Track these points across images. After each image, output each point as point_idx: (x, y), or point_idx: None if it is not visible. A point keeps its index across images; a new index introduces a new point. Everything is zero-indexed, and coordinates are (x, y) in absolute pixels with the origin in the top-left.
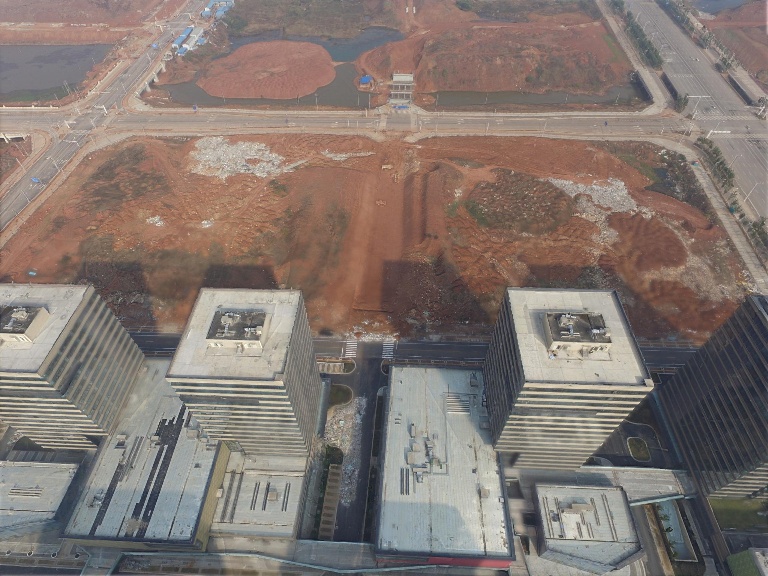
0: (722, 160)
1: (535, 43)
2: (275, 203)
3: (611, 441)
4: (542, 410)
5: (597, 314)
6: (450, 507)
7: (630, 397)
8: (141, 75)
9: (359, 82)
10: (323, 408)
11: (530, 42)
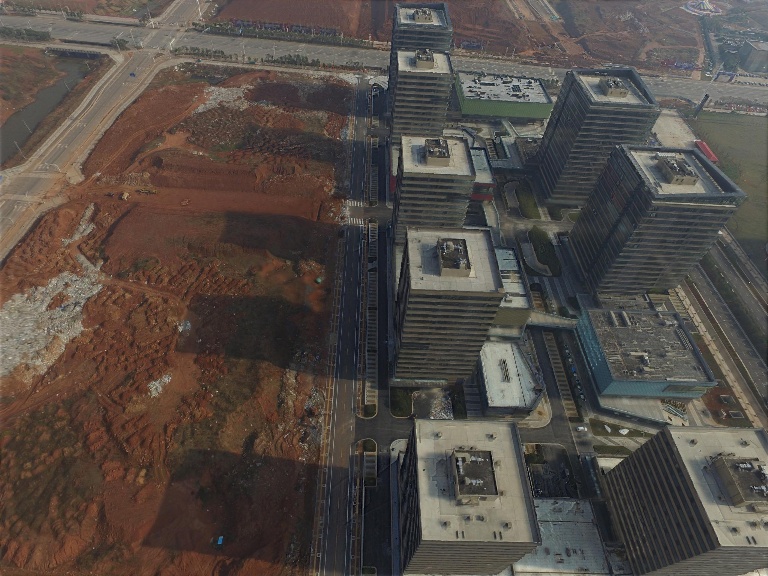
0: (205, 50)
1: None
2: (167, 268)
3: None
4: None
5: None
6: None
7: None
8: None
9: None
10: None
11: None
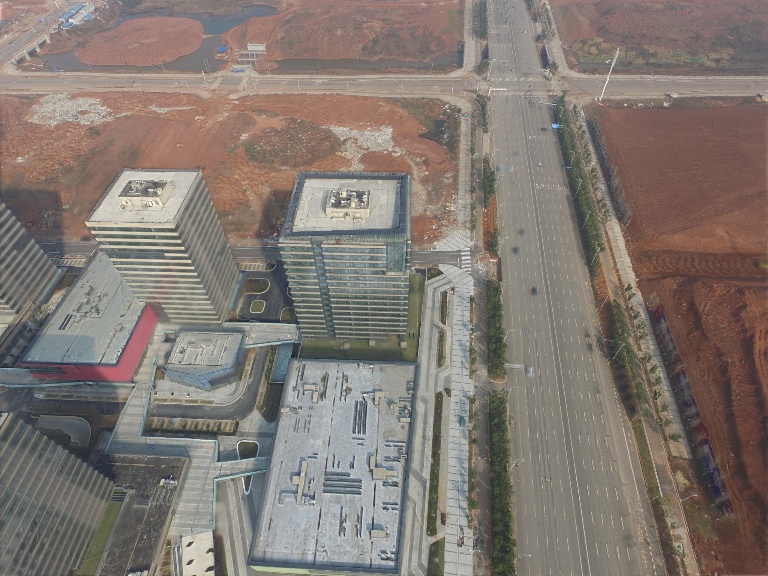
0: (485, 111)
1: (383, 17)
2: (85, 144)
3: (270, 310)
4: (125, 252)
5: (165, 182)
6: (90, 337)
7: (168, 235)
8: (23, 45)
9: (217, 51)
10: (51, 287)
11: (379, 16)
